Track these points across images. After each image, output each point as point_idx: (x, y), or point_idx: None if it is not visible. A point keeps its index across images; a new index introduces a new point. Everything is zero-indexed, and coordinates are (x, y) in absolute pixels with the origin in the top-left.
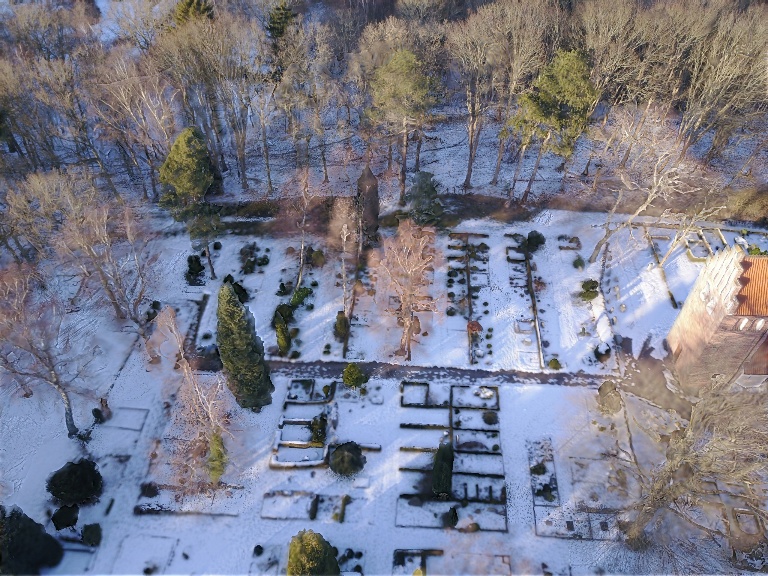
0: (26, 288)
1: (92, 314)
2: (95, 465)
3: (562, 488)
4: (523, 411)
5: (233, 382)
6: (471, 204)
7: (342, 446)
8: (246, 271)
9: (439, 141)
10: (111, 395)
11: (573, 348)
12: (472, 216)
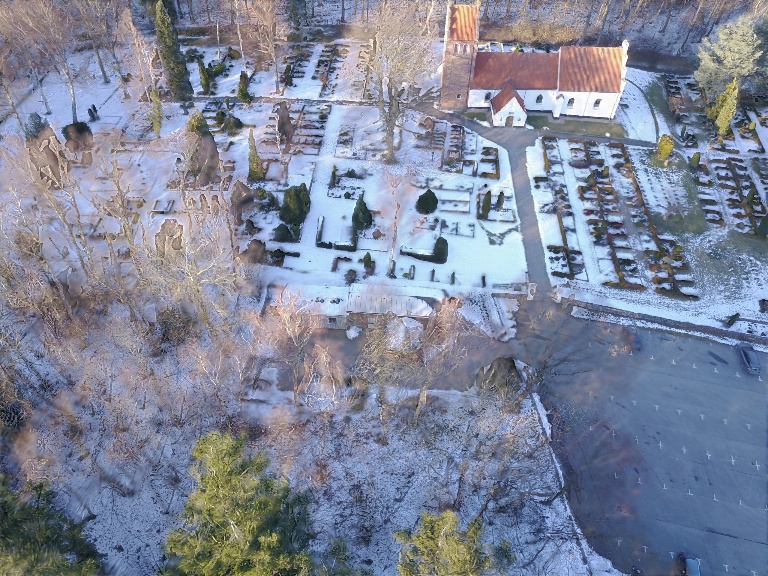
0: (53, 3)
1: (88, 82)
2: (89, 127)
3: (355, 142)
4: (344, 115)
5: (167, 75)
6: (343, 30)
7: (230, 117)
8: (188, 61)
9: (336, 7)
10: (99, 111)
11: (384, 92)
12: (342, 37)
